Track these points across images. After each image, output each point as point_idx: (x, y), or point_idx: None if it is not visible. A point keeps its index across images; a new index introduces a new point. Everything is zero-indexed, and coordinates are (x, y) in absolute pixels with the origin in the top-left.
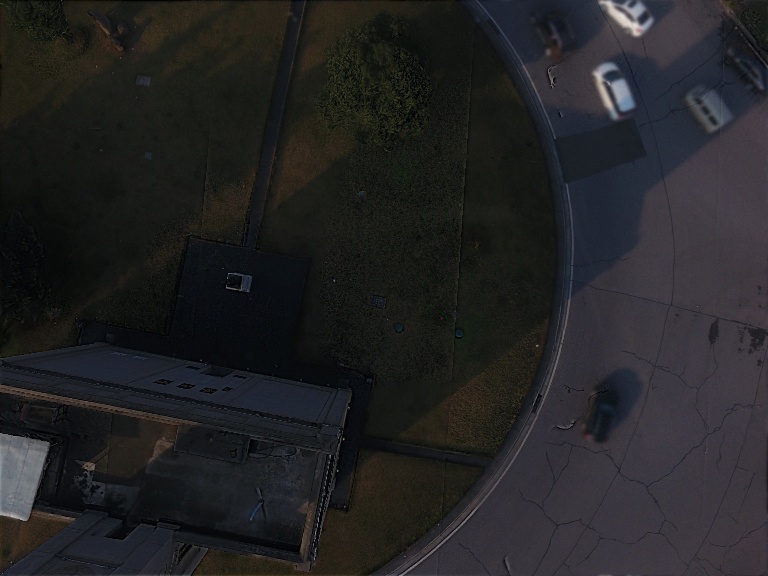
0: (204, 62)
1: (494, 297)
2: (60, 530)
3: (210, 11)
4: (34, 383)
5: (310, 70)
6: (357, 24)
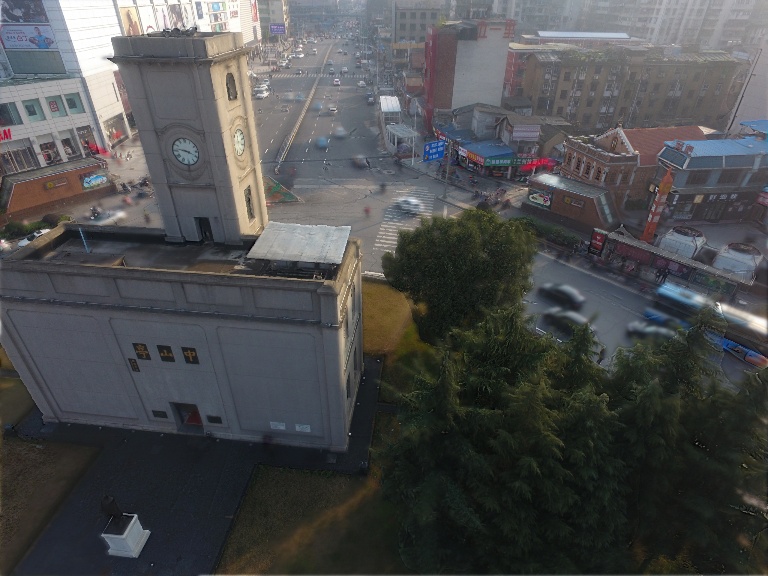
0: None
1: None
2: (374, 312)
3: None
4: (251, 286)
5: None
6: None
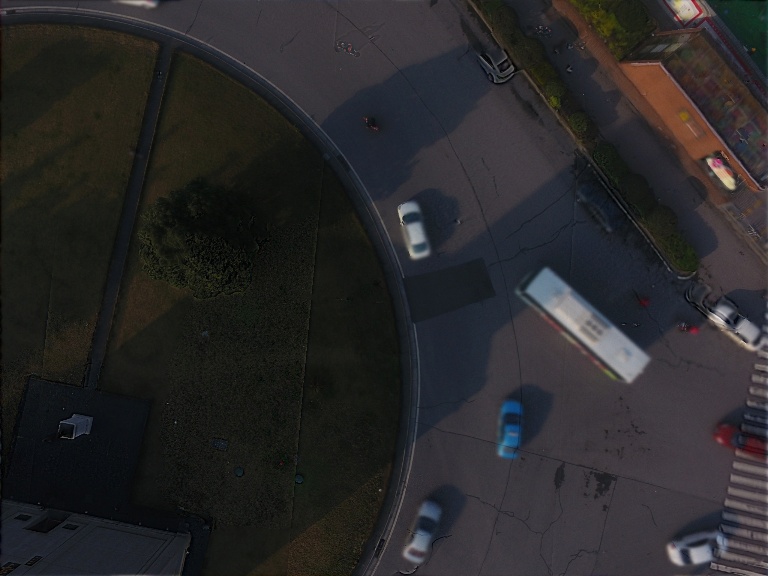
0: (48, 199)
1: (336, 441)
2: None
3: (56, 147)
4: None
5: None
6: (204, 161)
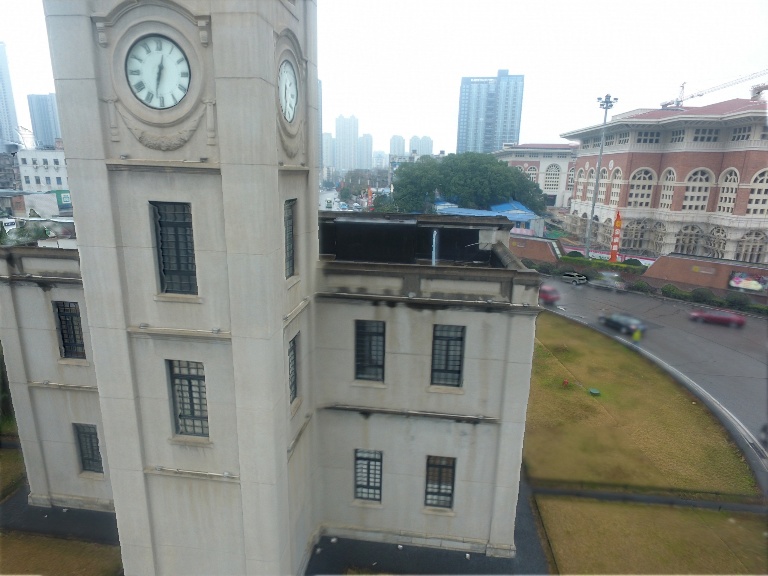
0: None
1: None
2: None
3: None
4: None
5: None
6: None
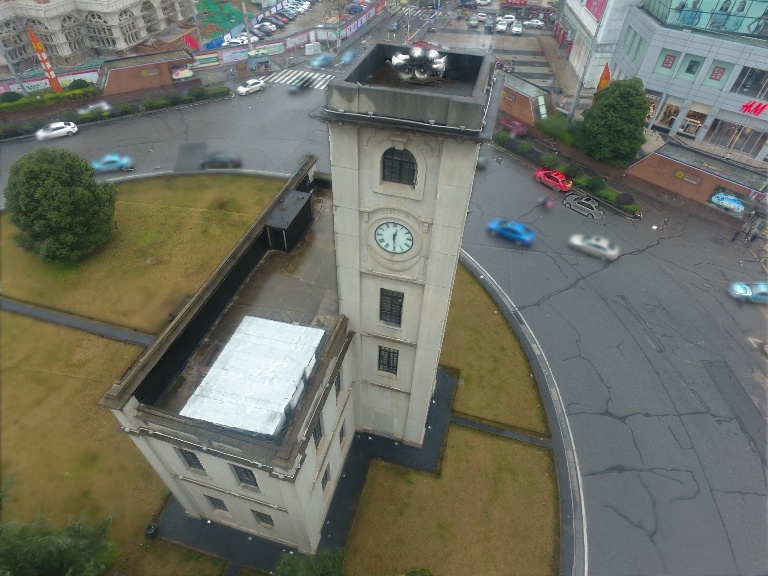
0: None
1: (269, 199)
2: None
3: None
4: None
5: (12, 284)
6: None
